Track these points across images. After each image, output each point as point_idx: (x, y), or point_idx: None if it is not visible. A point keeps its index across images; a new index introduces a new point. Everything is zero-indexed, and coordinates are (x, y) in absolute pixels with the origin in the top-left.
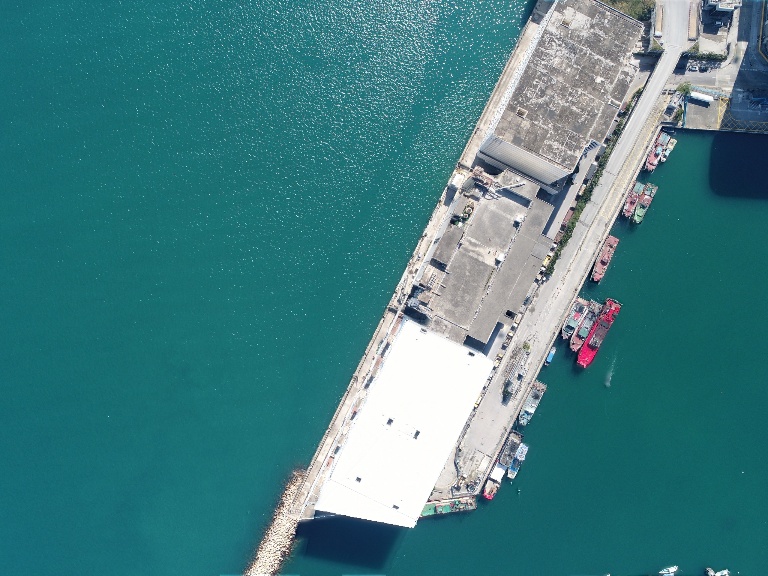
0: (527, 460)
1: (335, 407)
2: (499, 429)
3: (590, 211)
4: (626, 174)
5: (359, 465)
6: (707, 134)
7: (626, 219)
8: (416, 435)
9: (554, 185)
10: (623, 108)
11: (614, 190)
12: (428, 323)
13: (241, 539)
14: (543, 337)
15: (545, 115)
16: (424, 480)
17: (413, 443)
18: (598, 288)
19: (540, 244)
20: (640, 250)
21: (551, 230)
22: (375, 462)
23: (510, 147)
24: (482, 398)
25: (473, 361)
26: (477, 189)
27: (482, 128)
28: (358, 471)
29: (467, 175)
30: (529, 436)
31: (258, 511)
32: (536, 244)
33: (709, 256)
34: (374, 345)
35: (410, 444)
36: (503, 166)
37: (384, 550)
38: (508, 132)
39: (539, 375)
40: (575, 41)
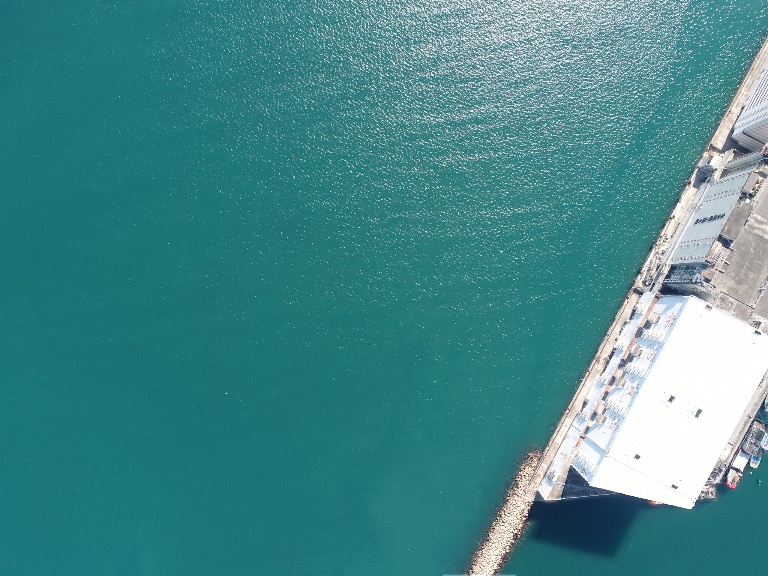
0: None
1: (575, 388)
2: (742, 417)
3: None
4: None
5: (638, 442)
6: None
7: None
8: (697, 414)
9: None
10: None
11: None
12: (707, 300)
13: (472, 519)
14: None
15: None
16: (705, 460)
17: (694, 422)
18: None
19: None
20: None
21: None
22: (655, 439)
23: None
24: None
25: (758, 340)
26: (767, 166)
27: (734, 111)
28: (636, 448)
29: (730, 156)
30: None
31: (490, 491)
32: None
33: None
34: (617, 326)
35: (691, 423)
36: None
37: (617, 537)
38: None
39: None
40: None
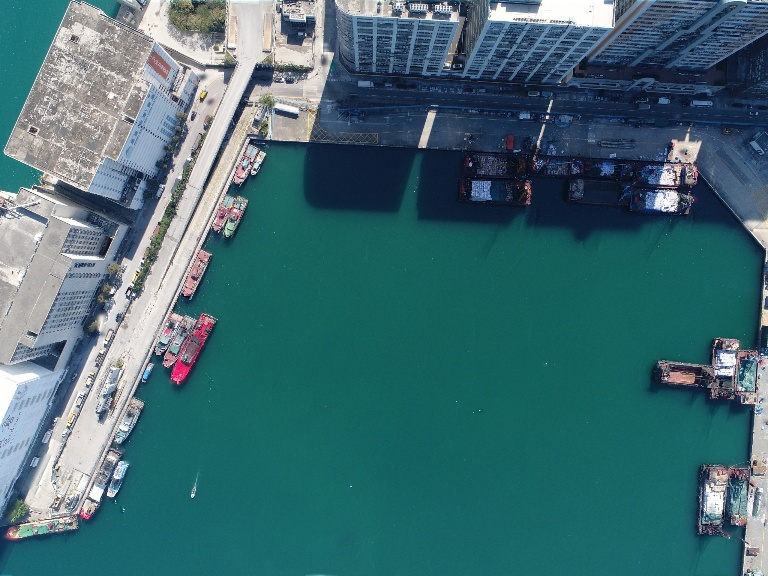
0: (130, 478)
1: None
2: (97, 448)
3: (177, 226)
4: (216, 188)
5: None
6: (299, 146)
7: None
8: None
9: (123, 201)
10: (205, 121)
11: (204, 204)
12: None
13: None
14: (138, 354)
15: (57, 132)
16: None
17: None
18: (195, 303)
19: (59, 263)
20: (237, 264)
21: (141, 245)
22: None
23: None
24: (75, 417)
25: None
26: None
27: None
28: None
29: None
30: (131, 454)
31: None
32: (54, 263)
33: (307, 269)
34: None
35: None
36: None
37: None
38: (20, 150)
39: (139, 392)
40: (85, 57)
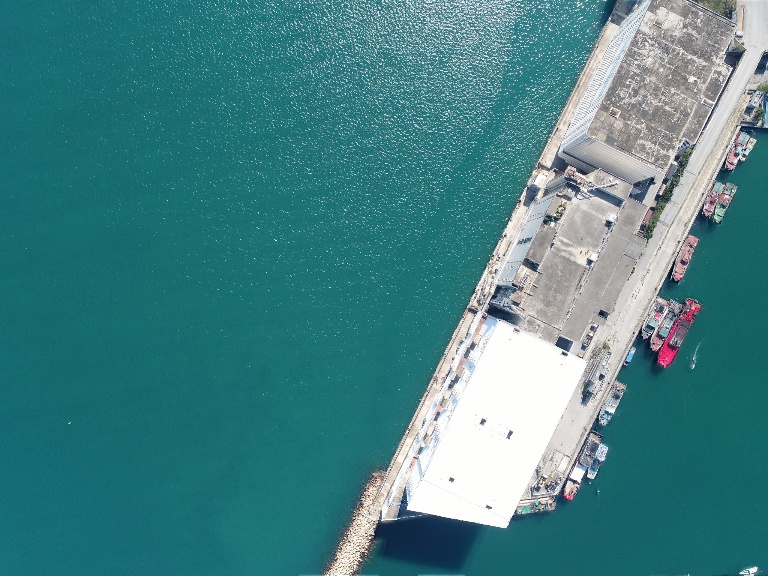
0: (606, 460)
1: (415, 408)
2: (579, 429)
3: (670, 211)
4: (705, 174)
5: (452, 465)
6: None
7: (705, 219)
8: (509, 435)
9: (637, 185)
10: None
11: (693, 190)
12: (519, 323)
13: (320, 540)
14: (623, 337)
15: (638, 115)
16: (517, 480)
17: (506, 443)
18: (677, 288)
19: (633, 243)
20: (719, 250)
21: None
22: (468, 462)
23: (602, 147)
24: None
25: (566, 361)
26: (570, 189)
27: (561, 128)
28: (451, 471)
29: (551, 175)
30: (608, 436)
31: (337, 512)
32: (629, 244)
33: None
34: (454, 345)
35: (503, 444)
36: (585, 166)
37: (463, 551)
38: (601, 132)
39: (618, 375)
40: (668, 41)
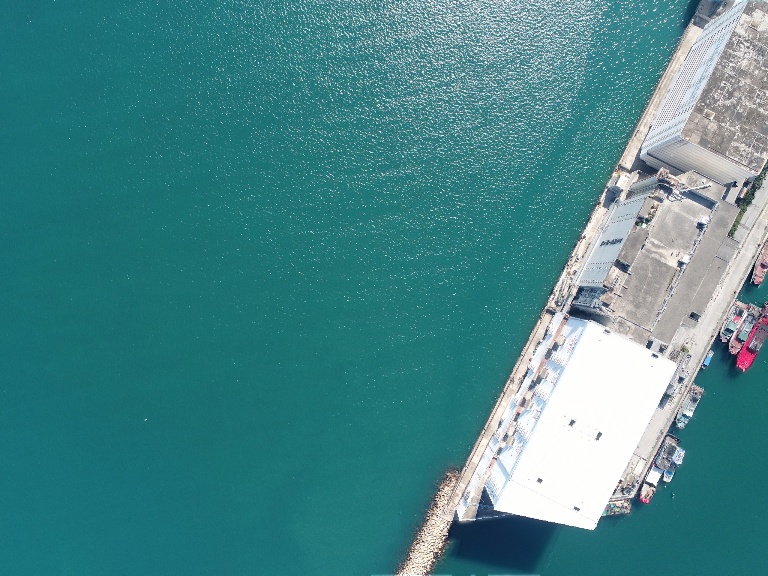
0: (682, 464)
1: (491, 408)
2: (655, 432)
3: (751, 214)
4: None
5: (540, 466)
6: None
7: None
8: (598, 436)
9: None
10: None
11: None
12: (608, 324)
13: (393, 540)
14: (701, 340)
15: (732, 117)
16: (606, 482)
17: (595, 444)
18: (756, 291)
19: (725, 246)
20: None
21: None
22: (557, 463)
23: (694, 149)
24: None
25: (656, 363)
26: (662, 190)
27: (642, 130)
28: (539, 472)
29: (635, 177)
30: (684, 440)
31: (410, 512)
32: (721, 246)
33: None
34: (531, 346)
35: (592, 445)
36: (669, 168)
37: (536, 553)
38: (695, 134)
39: (695, 378)
40: (763, 43)
